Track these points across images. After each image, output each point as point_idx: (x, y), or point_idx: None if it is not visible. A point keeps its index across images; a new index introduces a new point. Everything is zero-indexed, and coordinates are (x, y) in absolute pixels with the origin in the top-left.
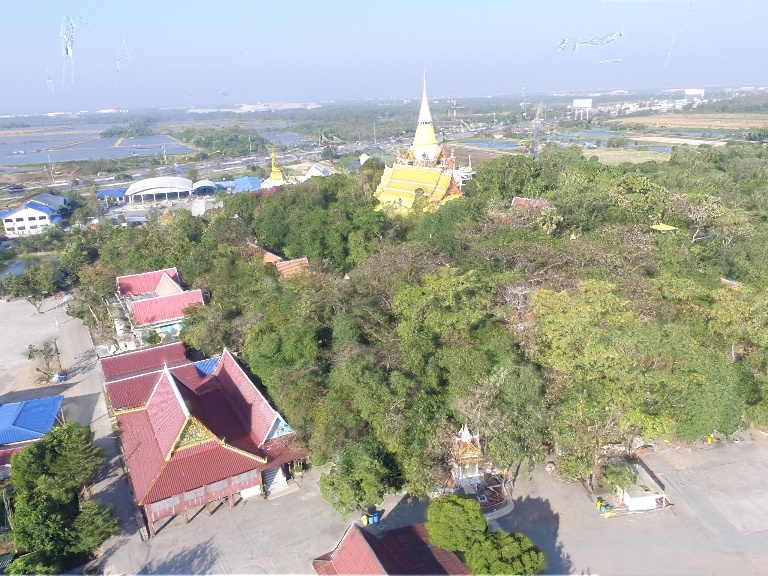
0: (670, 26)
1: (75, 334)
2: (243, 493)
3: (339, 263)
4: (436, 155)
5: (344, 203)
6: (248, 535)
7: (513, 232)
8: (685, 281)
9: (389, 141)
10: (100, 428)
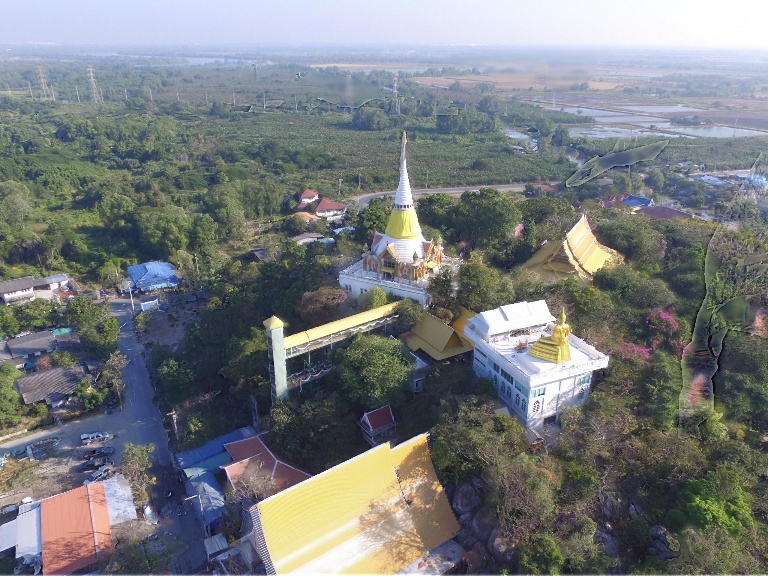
0: (555, 88)
1: None
2: None
3: None
4: None
5: None
6: None
7: None
8: None
9: None
10: None
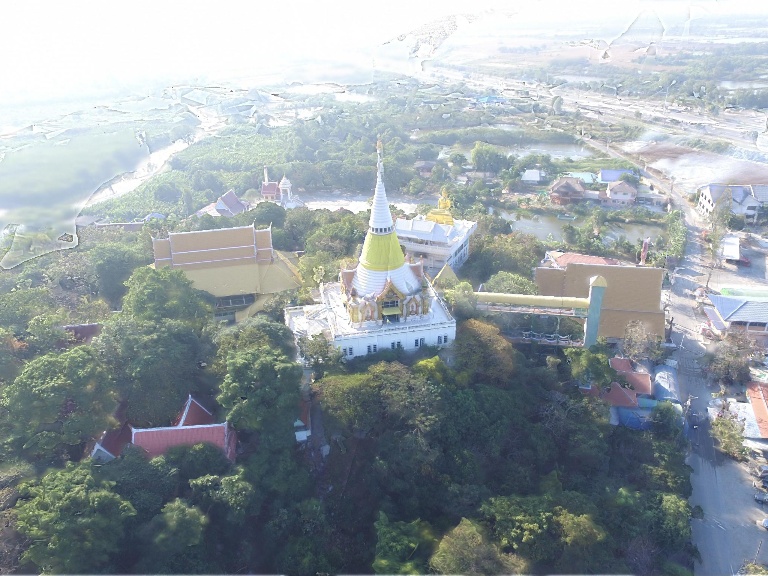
0: None
1: None
2: None
3: None
4: None
5: None
6: None
7: None
8: None
9: None
10: None
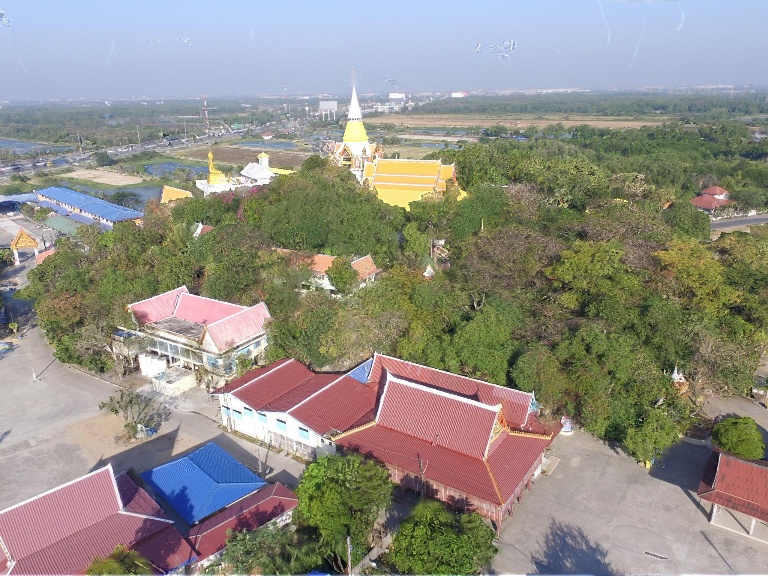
0: (636, 37)
1: (81, 384)
2: (535, 474)
3: (396, 257)
4: (372, 150)
5: (347, 200)
6: (577, 506)
7: (556, 211)
8: (690, 238)
9: (158, 144)
10: (285, 465)
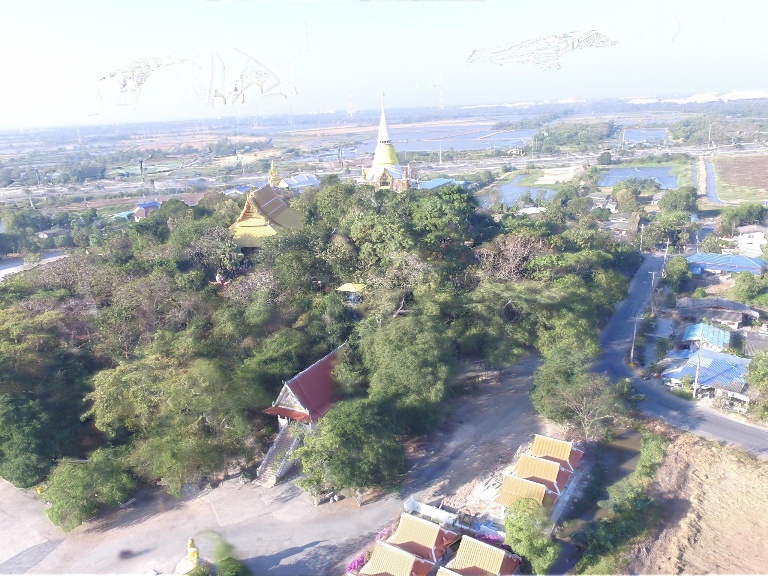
0: (288, 54)
1: None
2: None
3: None
4: (380, 176)
5: None
6: None
7: None
8: None
9: (722, 146)
10: None
